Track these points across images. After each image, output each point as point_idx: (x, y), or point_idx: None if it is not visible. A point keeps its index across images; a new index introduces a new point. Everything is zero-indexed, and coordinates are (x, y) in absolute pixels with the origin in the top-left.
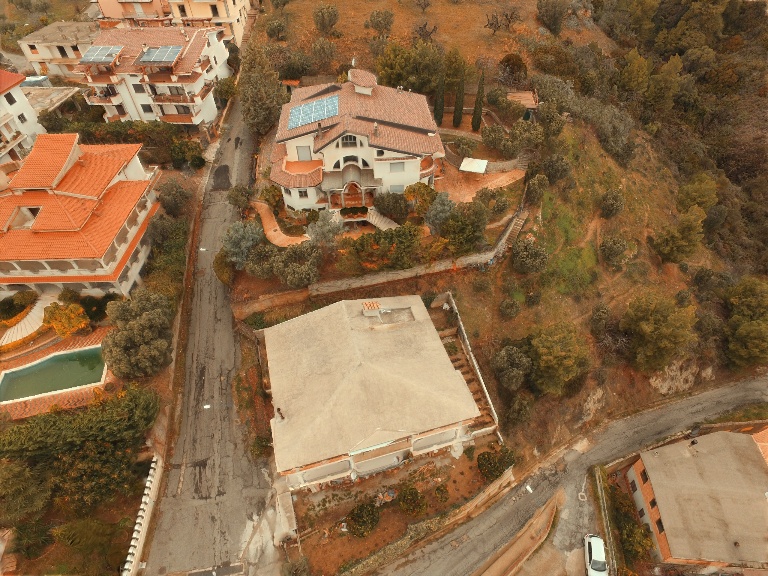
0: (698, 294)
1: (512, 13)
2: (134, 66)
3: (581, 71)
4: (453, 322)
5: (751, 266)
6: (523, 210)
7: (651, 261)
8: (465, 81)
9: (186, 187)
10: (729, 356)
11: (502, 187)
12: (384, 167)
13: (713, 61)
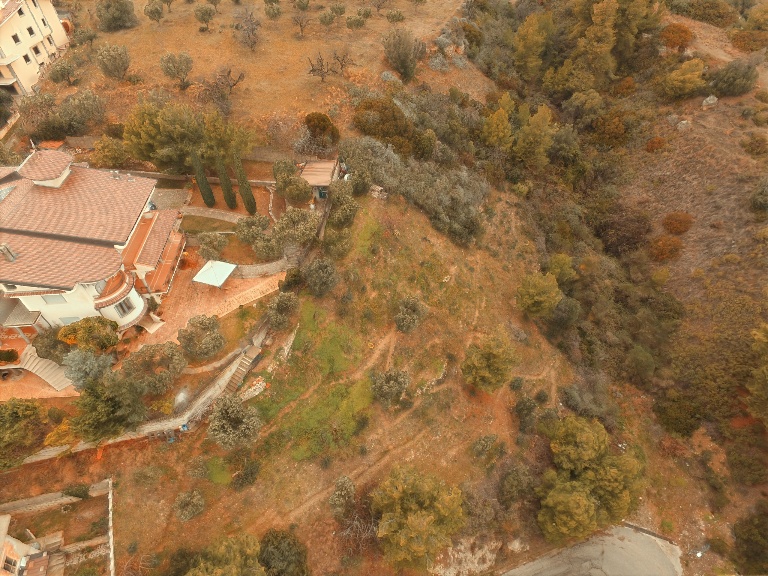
0: (521, 427)
1: (344, 56)
2: None
3: (424, 126)
4: (105, 527)
5: (603, 379)
6: (265, 338)
7: (463, 385)
8: (240, 151)
9: None
10: (540, 526)
11: (251, 301)
12: (33, 299)
13: (600, 107)
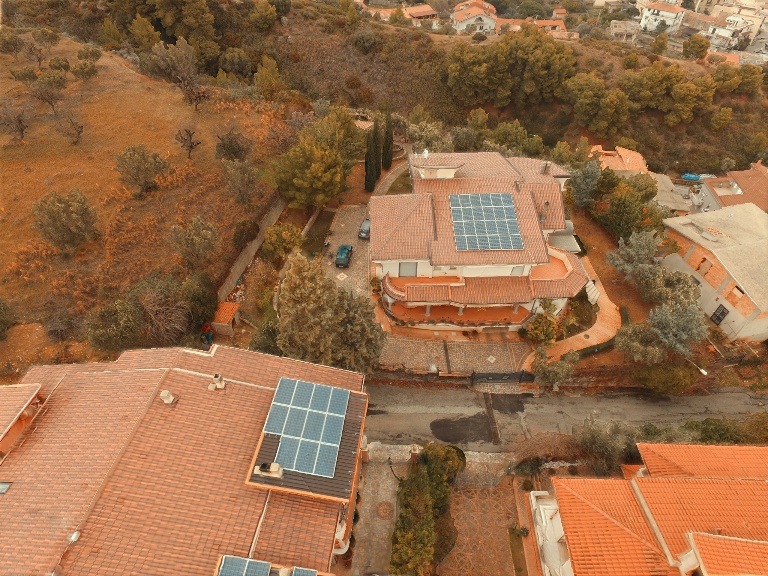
0: None
1: None
2: (350, 495)
3: None
4: None
5: None
6: None
7: None
8: None
9: (549, 448)
10: None
11: None
12: None
13: None
